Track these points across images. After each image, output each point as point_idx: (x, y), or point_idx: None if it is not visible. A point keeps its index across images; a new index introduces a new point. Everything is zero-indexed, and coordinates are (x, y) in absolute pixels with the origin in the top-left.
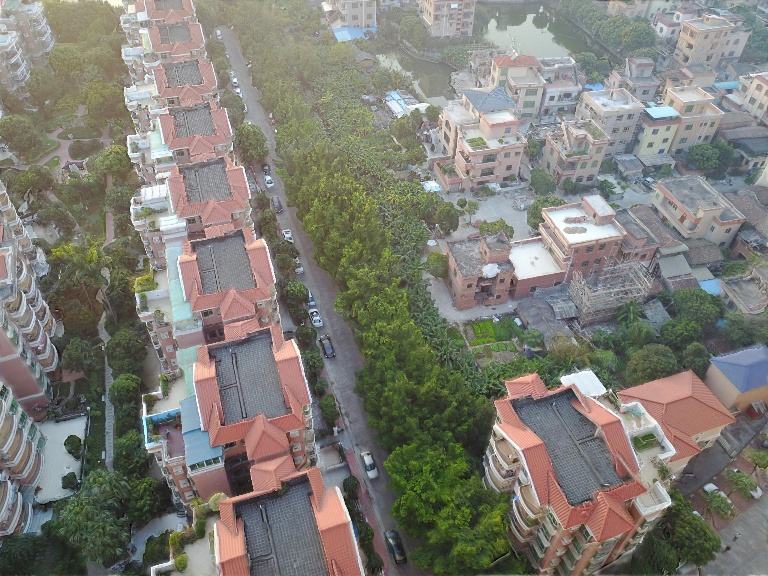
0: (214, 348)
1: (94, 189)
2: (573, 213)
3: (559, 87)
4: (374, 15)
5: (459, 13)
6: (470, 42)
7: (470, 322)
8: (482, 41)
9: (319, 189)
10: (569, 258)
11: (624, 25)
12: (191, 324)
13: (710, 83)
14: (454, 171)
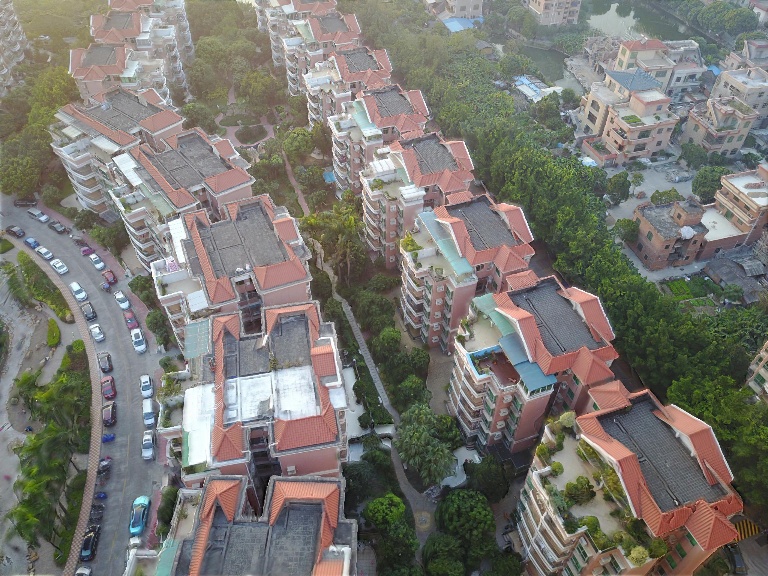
0: (510, 295)
1: (281, 169)
2: (750, 180)
3: (686, 69)
4: (480, 6)
5: (567, 2)
6: (578, 30)
7: (665, 281)
8: (588, 28)
9: (515, 162)
10: (755, 220)
11: (726, 10)
12: (467, 277)
13: None
14: (604, 148)
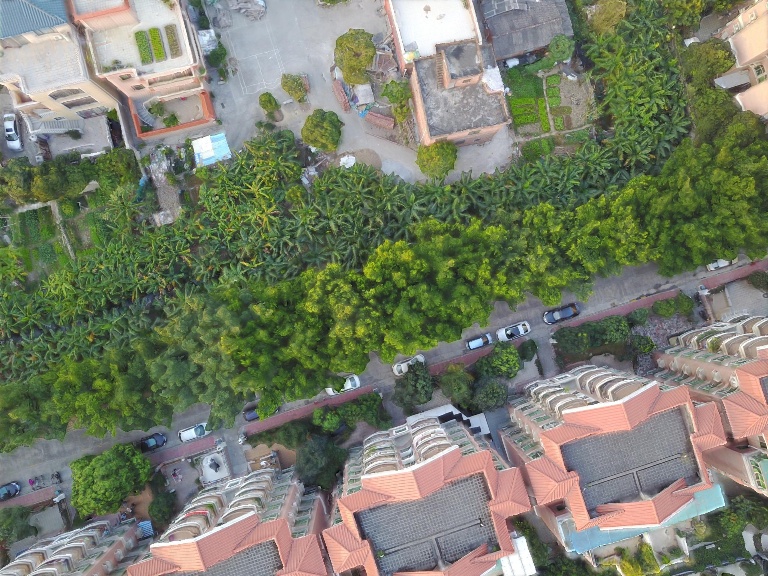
0: None
1: None
2: None
3: None
4: None
5: None
6: None
7: (513, 126)
8: None
9: None
10: None
11: None
12: None
13: None
14: None
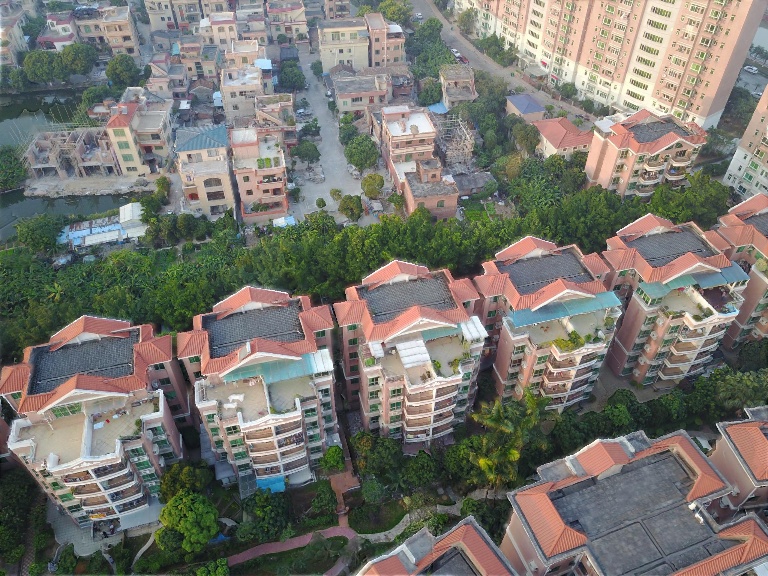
0: None
1: None
2: (392, 127)
3: (166, 110)
4: None
5: None
6: None
7: None
8: None
9: (364, 250)
10: None
11: (55, 57)
12: None
13: (202, 44)
14: (261, 205)
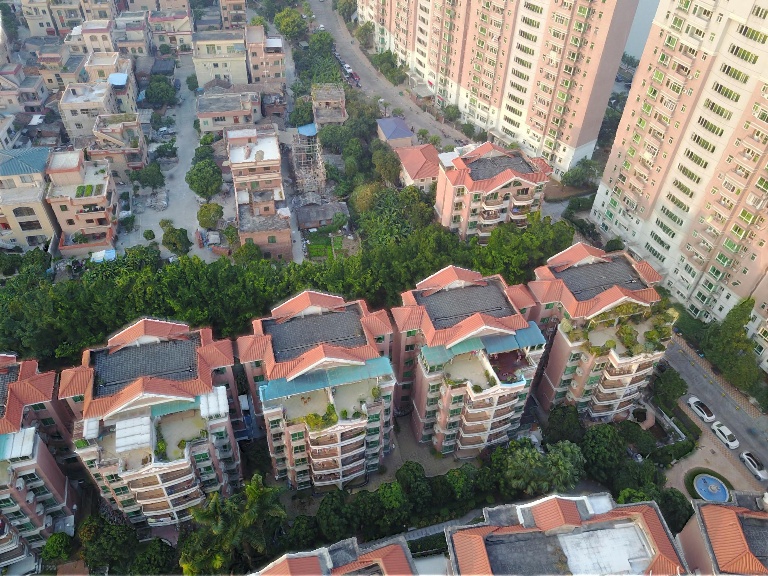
0: None
1: None
2: (236, 153)
3: (1, 127)
4: None
5: None
6: None
7: (308, 256)
8: None
9: (146, 298)
10: None
11: None
12: None
13: (67, 54)
14: (84, 236)
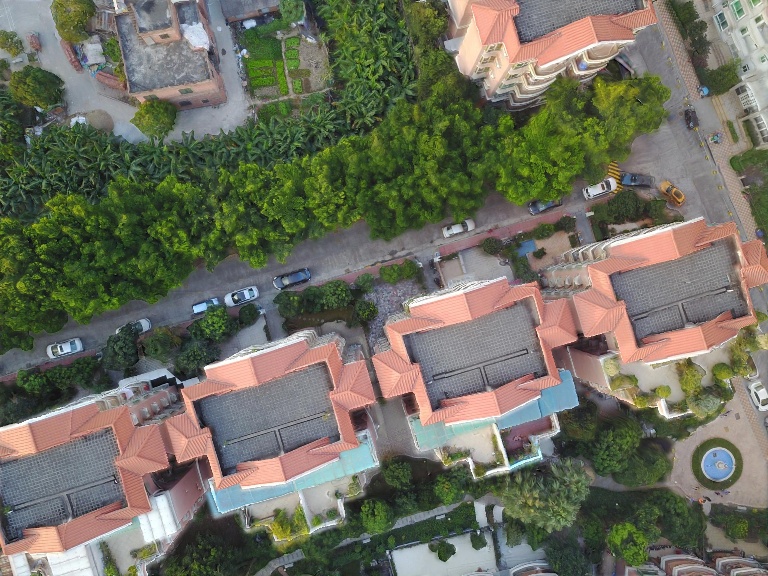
0: None
1: None
2: None
3: None
4: None
5: None
6: None
7: (248, 89)
8: None
9: (21, 293)
10: None
11: None
12: None
13: None
14: None
